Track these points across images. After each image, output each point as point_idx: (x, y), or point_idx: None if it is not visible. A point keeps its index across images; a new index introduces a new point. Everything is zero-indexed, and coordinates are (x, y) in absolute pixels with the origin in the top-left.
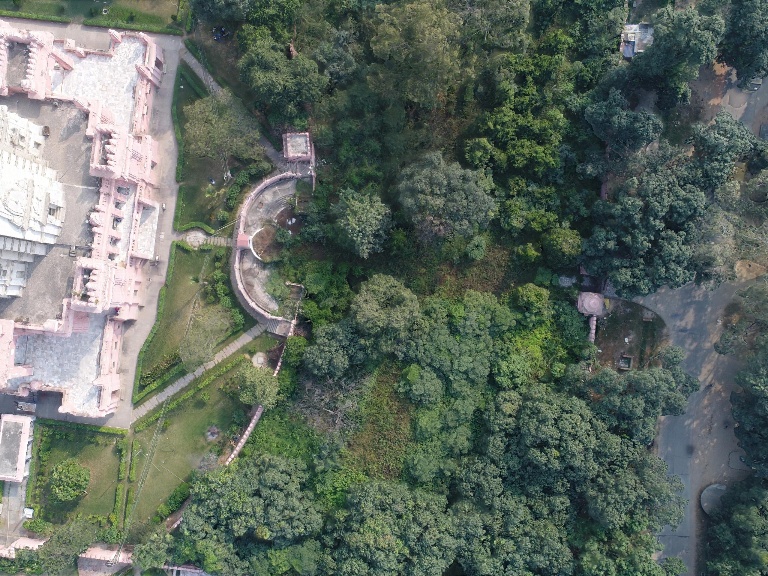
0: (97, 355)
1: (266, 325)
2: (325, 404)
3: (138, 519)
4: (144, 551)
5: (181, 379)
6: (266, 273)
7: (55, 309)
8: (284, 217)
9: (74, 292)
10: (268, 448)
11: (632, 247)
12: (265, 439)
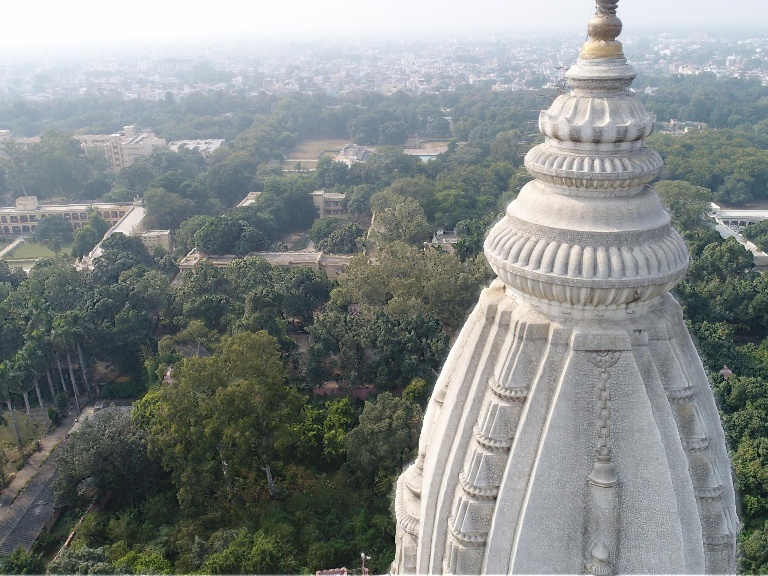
0: None
1: None
2: None
3: None
4: None
5: None
6: None
7: None
8: None
9: None
10: None
11: (415, 344)
12: None
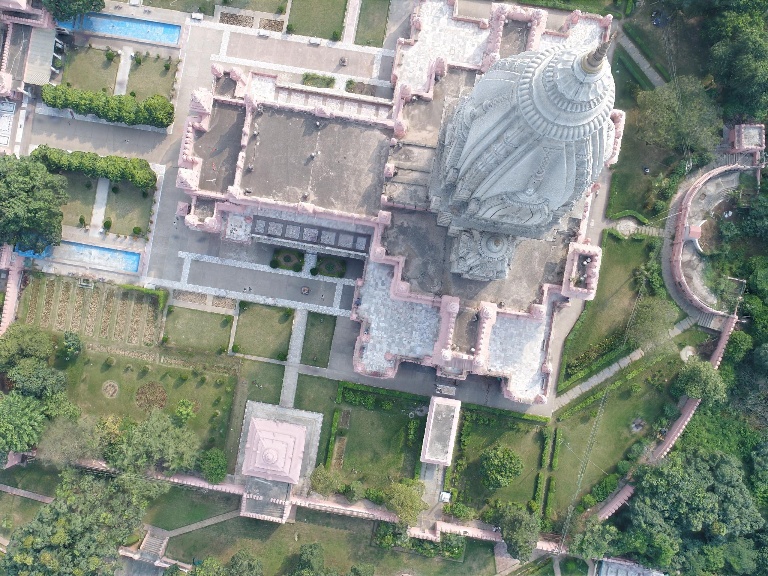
0: (542, 342)
1: (696, 318)
2: (765, 402)
3: (557, 508)
4: (586, 541)
5: (606, 369)
6: (701, 266)
7: (531, 294)
8: (721, 209)
9: (572, 278)
10: (698, 443)
11: None
12: (696, 434)
